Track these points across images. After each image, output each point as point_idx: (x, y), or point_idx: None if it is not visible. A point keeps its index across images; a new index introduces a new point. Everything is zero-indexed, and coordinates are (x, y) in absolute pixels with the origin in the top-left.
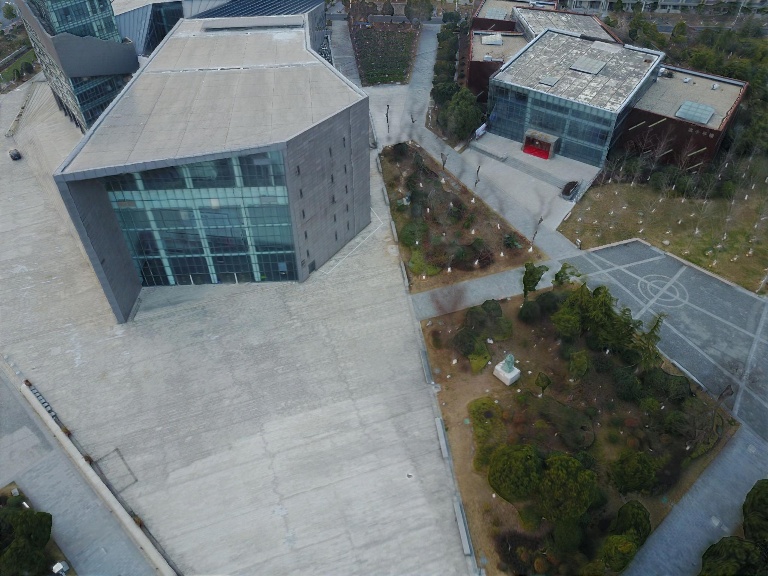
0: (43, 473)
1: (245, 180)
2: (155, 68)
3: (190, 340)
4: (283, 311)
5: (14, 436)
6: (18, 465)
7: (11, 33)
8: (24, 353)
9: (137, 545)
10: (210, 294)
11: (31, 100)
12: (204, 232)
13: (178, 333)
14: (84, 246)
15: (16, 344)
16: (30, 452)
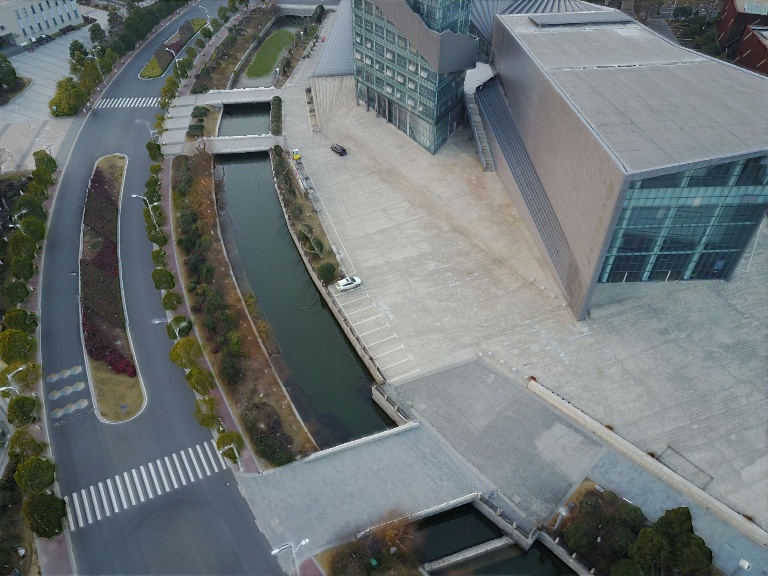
0: (610, 469)
1: (739, 179)
2: (551, 65)
3: (661, 338)
4: (732, 309)
5: (554, 432)
6: (579, 461)
7: (240, 27)
8: (504, 349)
9: (758, 542)
10: (648, 292)
11: (318, 95)
12: (667, 230)
13: (644, 331)
14: (603, 244)
15: (490, 340)
16: (581, 448)
